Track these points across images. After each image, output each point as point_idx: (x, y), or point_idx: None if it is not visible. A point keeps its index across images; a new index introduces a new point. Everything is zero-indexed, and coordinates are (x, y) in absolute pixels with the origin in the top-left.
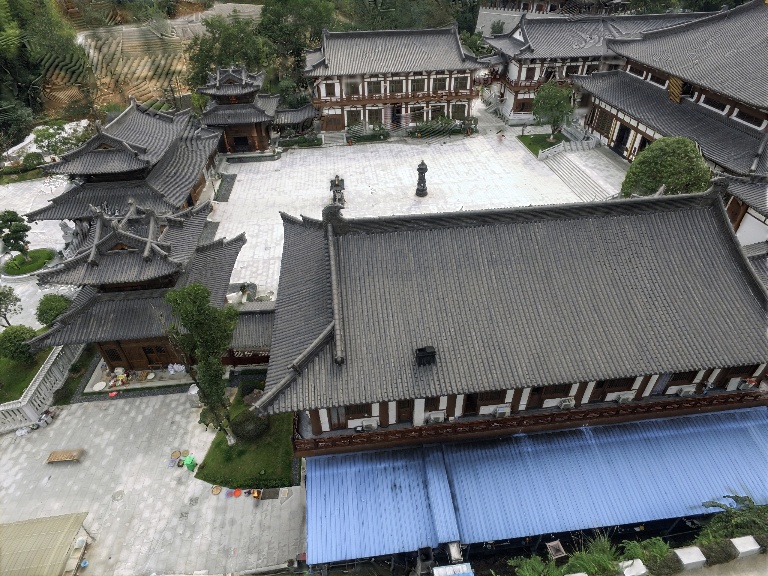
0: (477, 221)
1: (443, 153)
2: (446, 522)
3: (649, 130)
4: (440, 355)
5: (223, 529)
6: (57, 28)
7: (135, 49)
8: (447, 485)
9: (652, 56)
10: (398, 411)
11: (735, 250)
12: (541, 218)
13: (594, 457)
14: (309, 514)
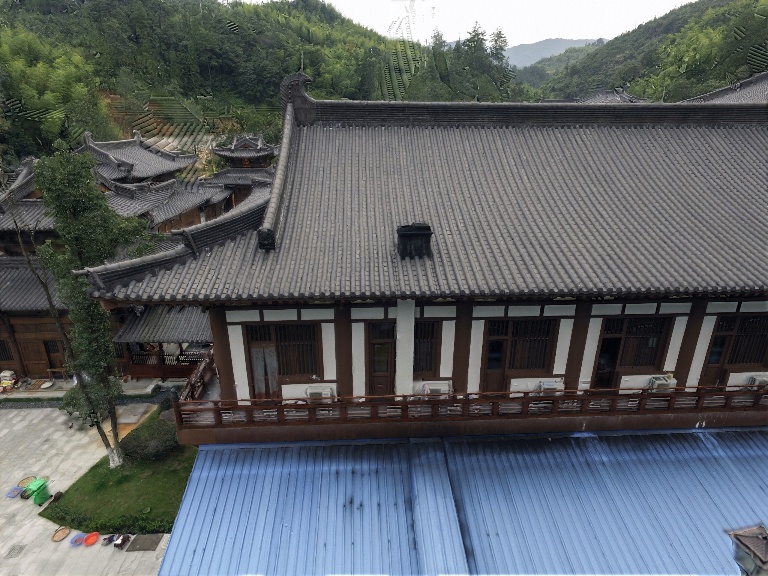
0: (498, 118)
1: None
2: (447, 570)
3: None
4: (440, 248)
5: None
6: (95, 107)
7: (159, 116)
8: (451, 503)
9: None
10: (369, 374)
11: None
12: (588, 122)
13: (731, 478)
14: (173, 542)
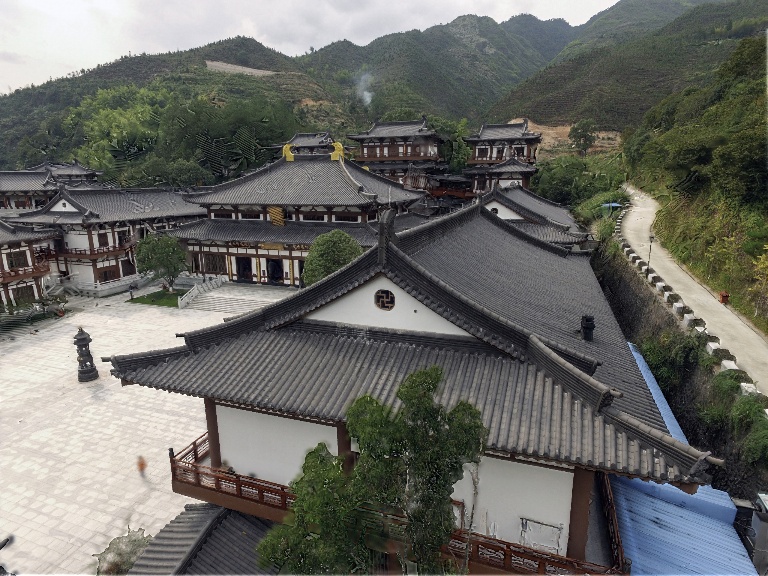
0: (442, 231)
1: (50, 339)
2: (707, 494)
3: (272, 251)
4: None
5: None
6: None
7: None
8: None
9: (238, 199)
10: None
11: (515, 231)
12: None
13: None
14: None
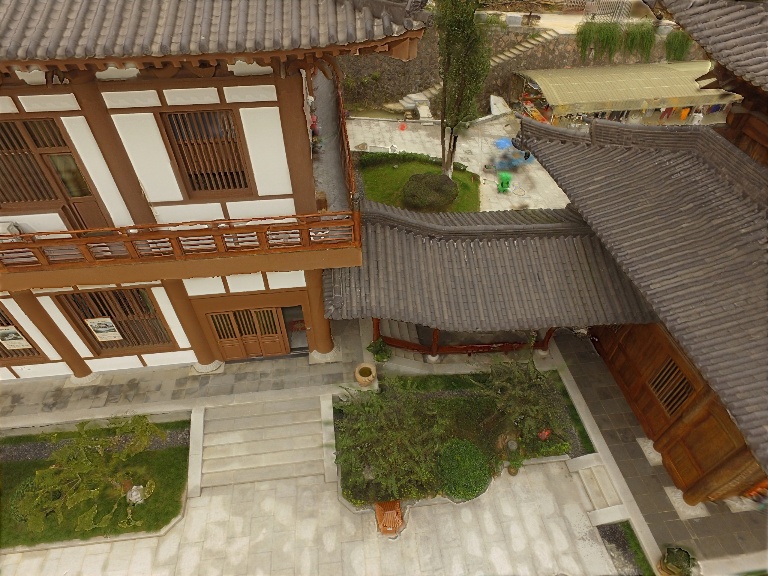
0: None
1: None
2: None
3: None
4: None
5: (421, 140)
6: None
7: None
8: None
9: None
10: None
11: None
12: None
13: None
14: None
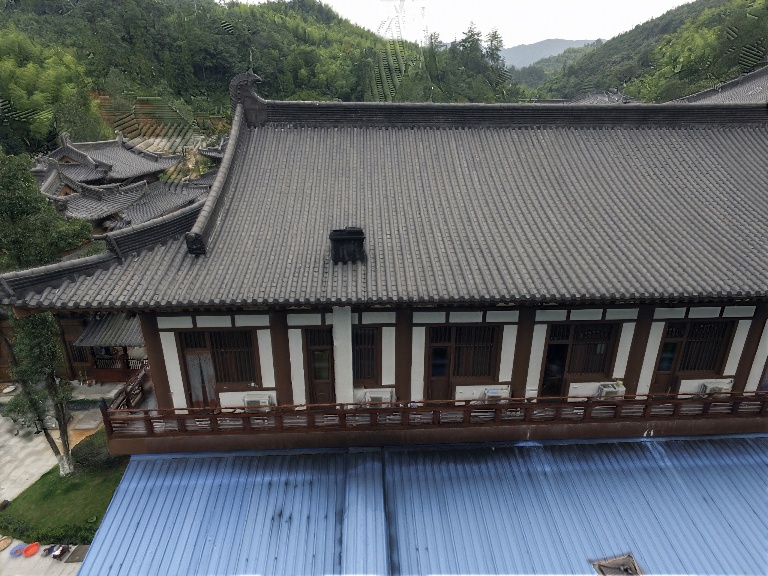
0: (453, 119)
1: None
2: None
3: None
4: (375, 253)
5: None
6: (84, 107)
7: (146, 116)
8: (381, 516)
9: None
10: (309, 382)
11: None
12: (546, 122)
13: (675, 489)
14: (91, 557)
